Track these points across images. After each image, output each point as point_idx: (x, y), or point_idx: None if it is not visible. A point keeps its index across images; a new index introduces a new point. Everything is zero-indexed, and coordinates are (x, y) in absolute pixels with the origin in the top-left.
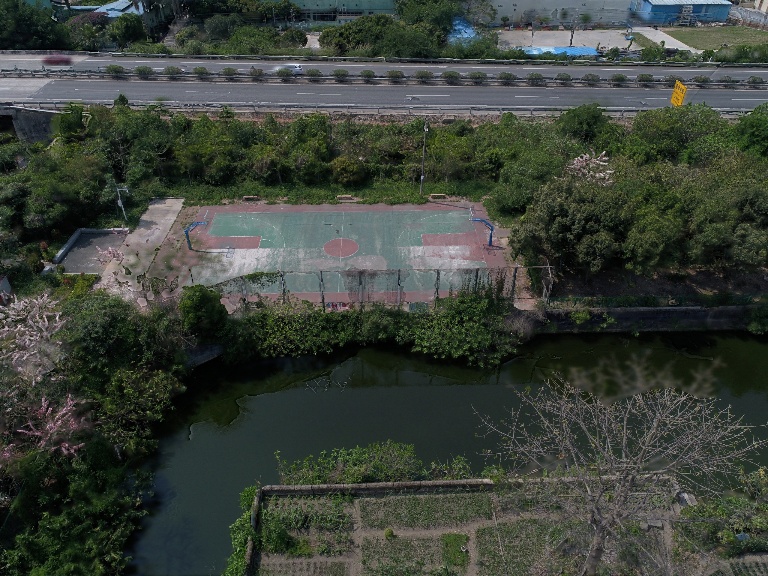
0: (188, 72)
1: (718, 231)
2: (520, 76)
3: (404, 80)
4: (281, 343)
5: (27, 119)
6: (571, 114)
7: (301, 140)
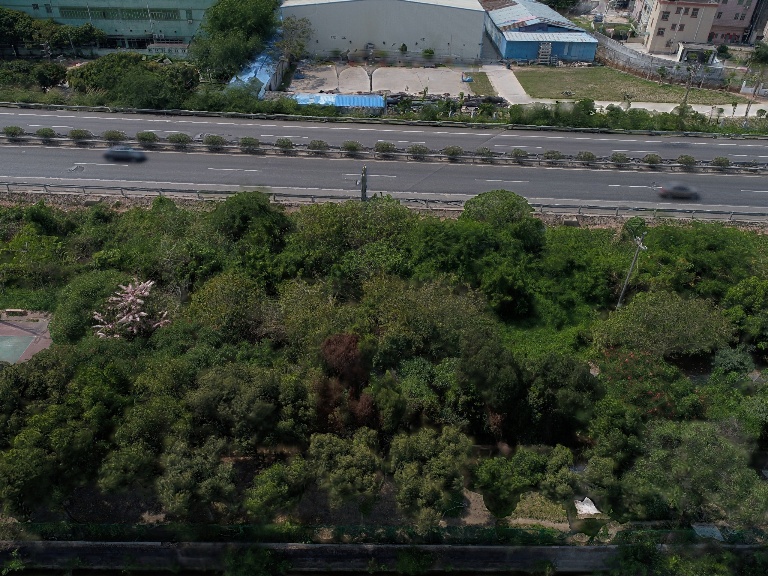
0: None
1: (123, 458)
2: None
3: (91, 141)
4: None
5: None
6: (224, 204)
7: None
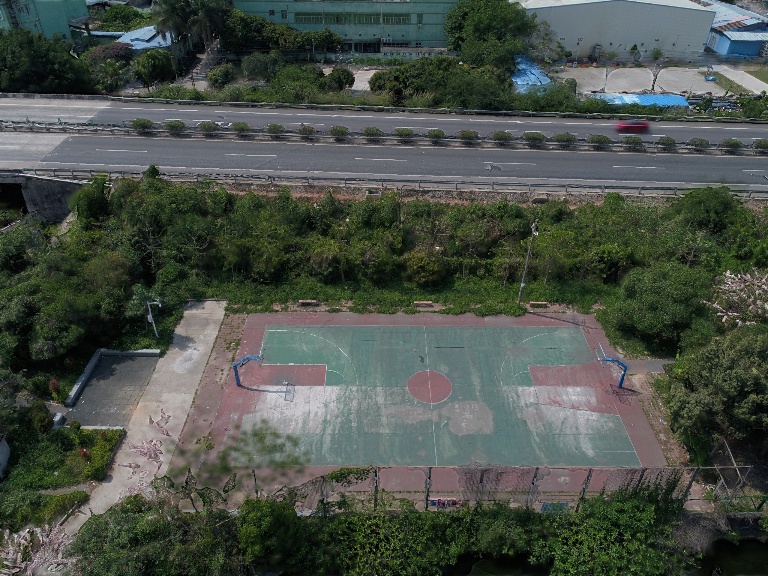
0: (227, 128)
1: None
2: (611, 136)
3: (478, 142)
4: (375, 570)
5: (39, 188)
6: (694, 199)
7: (366, 225)
